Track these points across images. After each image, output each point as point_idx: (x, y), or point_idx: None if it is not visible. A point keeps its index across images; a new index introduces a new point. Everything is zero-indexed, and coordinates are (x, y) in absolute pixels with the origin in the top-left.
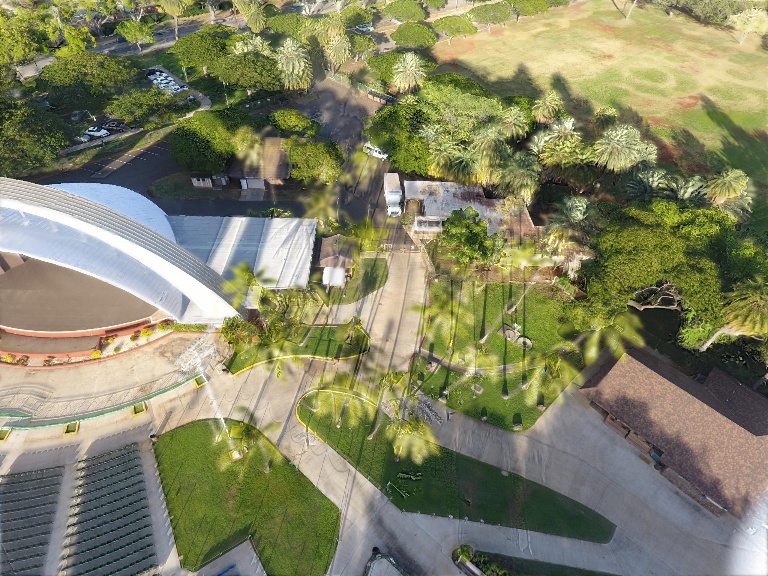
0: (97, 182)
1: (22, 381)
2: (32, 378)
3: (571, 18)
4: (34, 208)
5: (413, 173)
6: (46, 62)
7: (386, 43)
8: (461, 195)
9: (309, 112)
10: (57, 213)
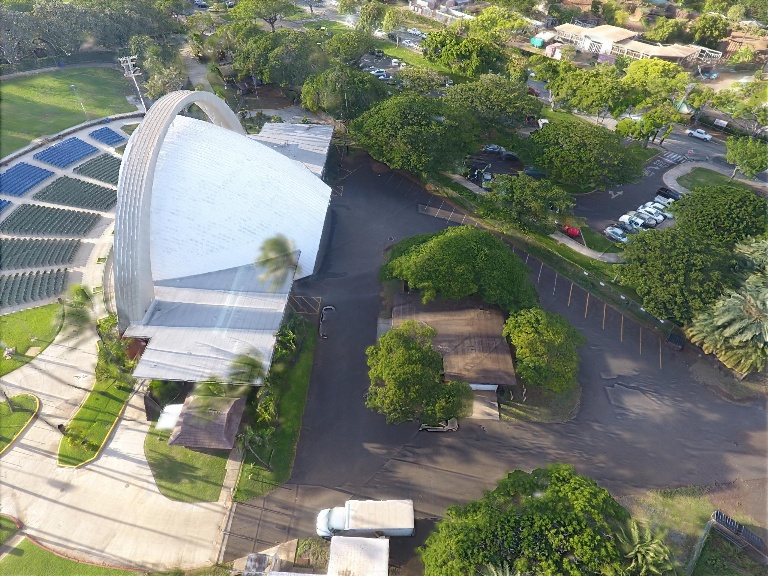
0: (410, 210)
1: None
2: None
3: None
4: None
5: None
6: None
7: None
8: None
9: (665, 386)
10: None
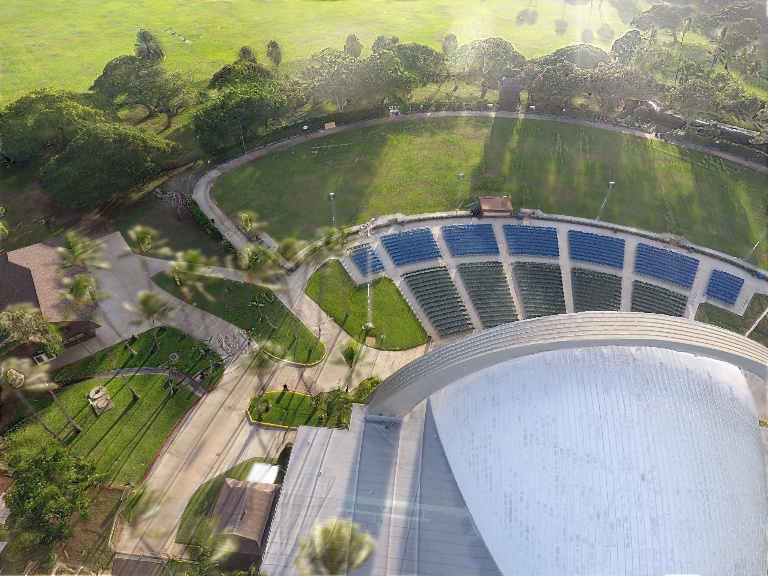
0: None
1: None
2: None
3: None
4: None
5: None
6: None
7: None
8: None
9: None
10: None
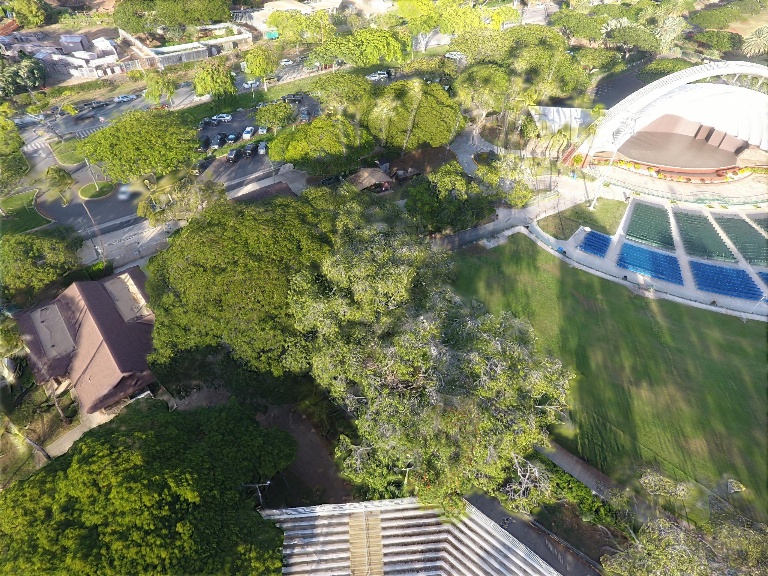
0: (592, 104)
1: (698, 189)
2: (701, 188)
3: None
4: None
5: None
6: (443, 35)
7: None
8: None
9: None
10: None
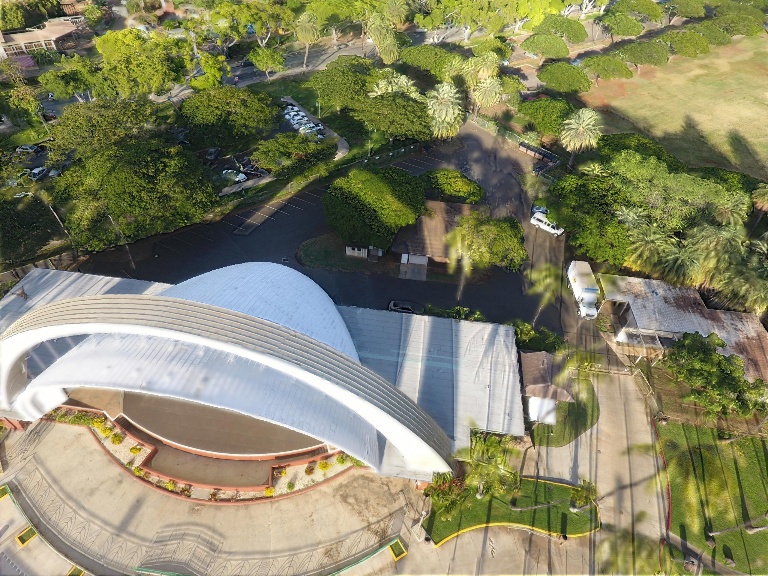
0: (240, 240)
1: (186, 520)
2: (197, 517)
3: (729, 59)
4: (258, 356)
5: (604, 262)
6: None
7: (525, 81)
8: (675, 301)
9: (457, 164)
10: (283, 363)
